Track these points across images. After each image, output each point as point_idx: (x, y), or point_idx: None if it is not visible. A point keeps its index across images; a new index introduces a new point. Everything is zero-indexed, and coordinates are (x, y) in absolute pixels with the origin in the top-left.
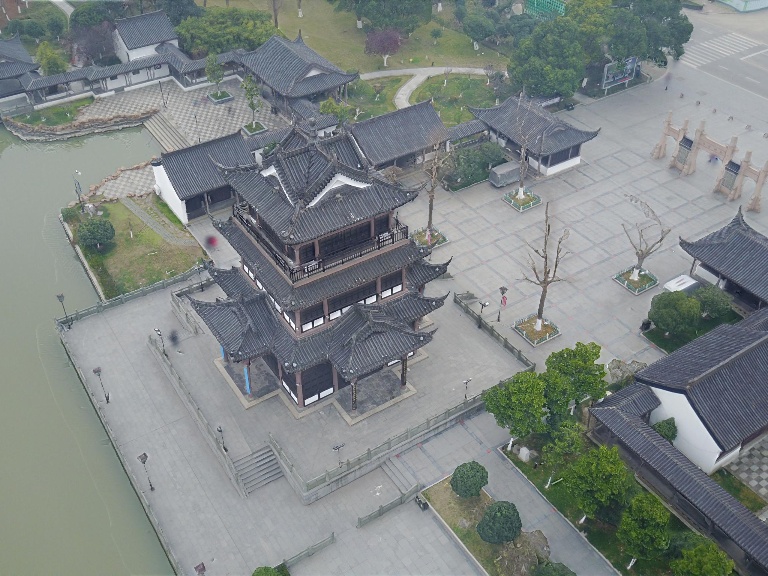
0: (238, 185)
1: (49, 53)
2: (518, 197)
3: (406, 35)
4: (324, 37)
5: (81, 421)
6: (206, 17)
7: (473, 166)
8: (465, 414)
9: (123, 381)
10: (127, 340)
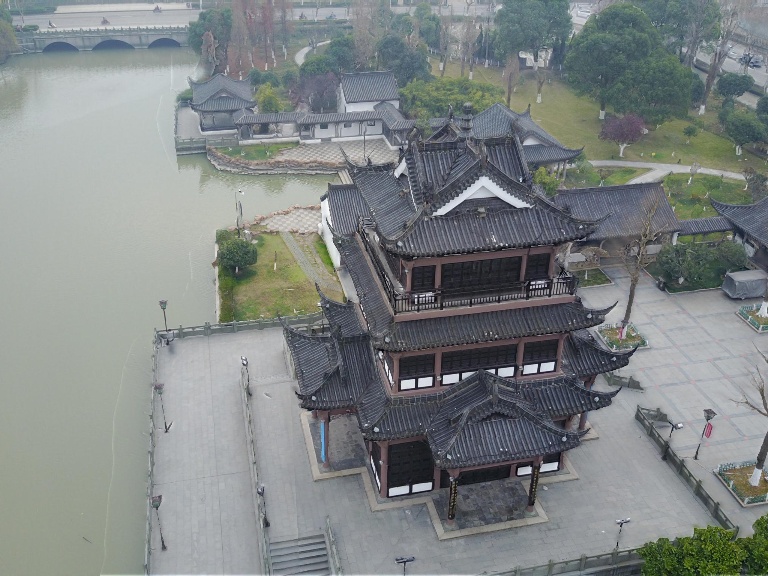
0: (364, 186)
1: (267, 92)
2: (759, 314)
3: (653, 127)
4: (558, 122)
5: (132, 446)
6: (434, 83)
7: (702, 264)
8: (611, 572)
9: (194, 413)
10: (220, 370)
